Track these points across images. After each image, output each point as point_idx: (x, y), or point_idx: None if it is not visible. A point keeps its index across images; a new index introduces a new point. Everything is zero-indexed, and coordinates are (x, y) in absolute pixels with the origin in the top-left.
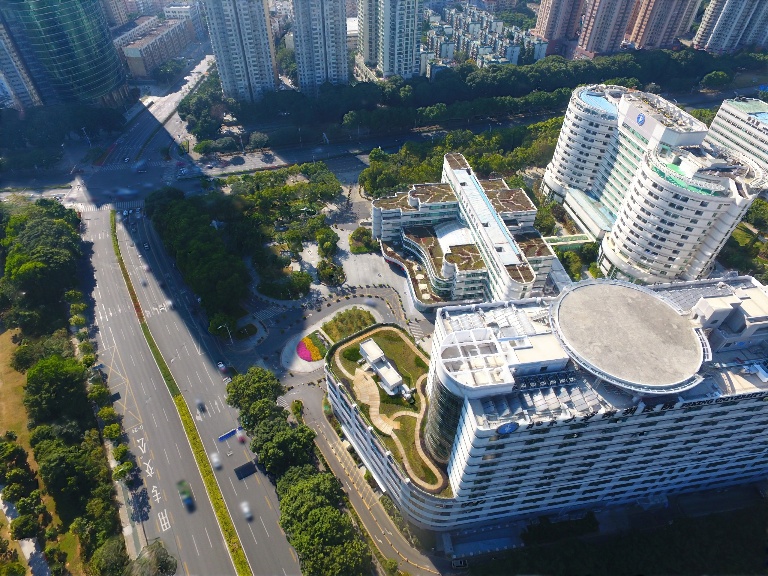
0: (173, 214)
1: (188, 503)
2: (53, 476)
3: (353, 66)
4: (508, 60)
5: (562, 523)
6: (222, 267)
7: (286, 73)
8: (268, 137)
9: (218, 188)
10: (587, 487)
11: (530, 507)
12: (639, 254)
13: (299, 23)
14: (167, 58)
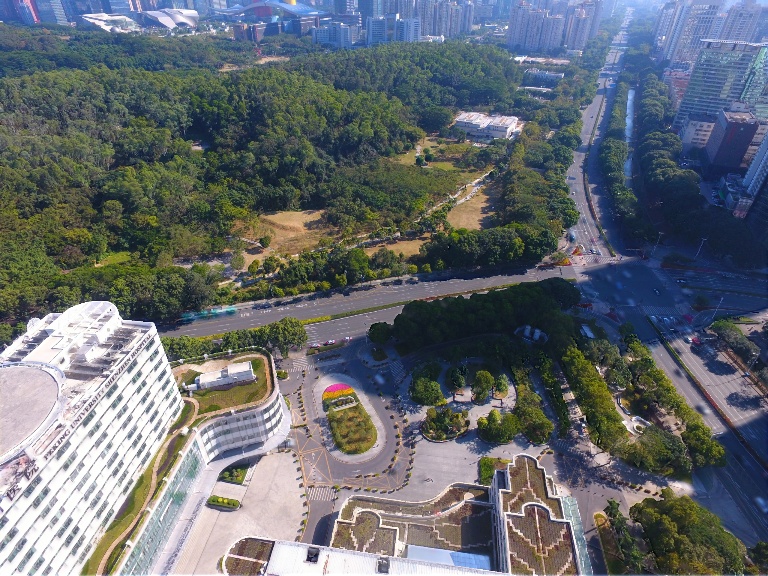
0: None
1: None
2: (288, 268)
3: None
4: None
5: None
6: (419, 312)
7: None
8: None
9: None
10: None
11: None
12: None
13: None
14: None
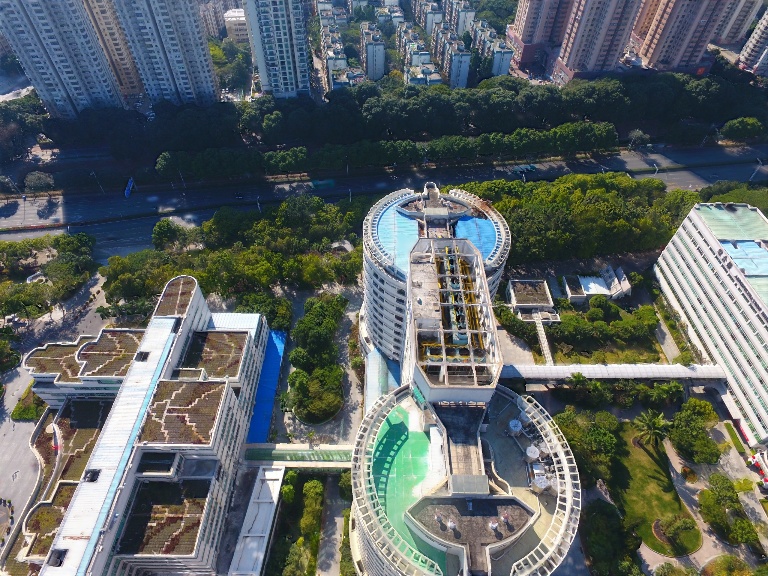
0: None
1: None
2: None
3: None
4: (440, 78)
5: None
6: None
7: None
8: (53, 179)
9: None
10: None
11: None
12: (365, 565)
13: (125, 17)
14: None
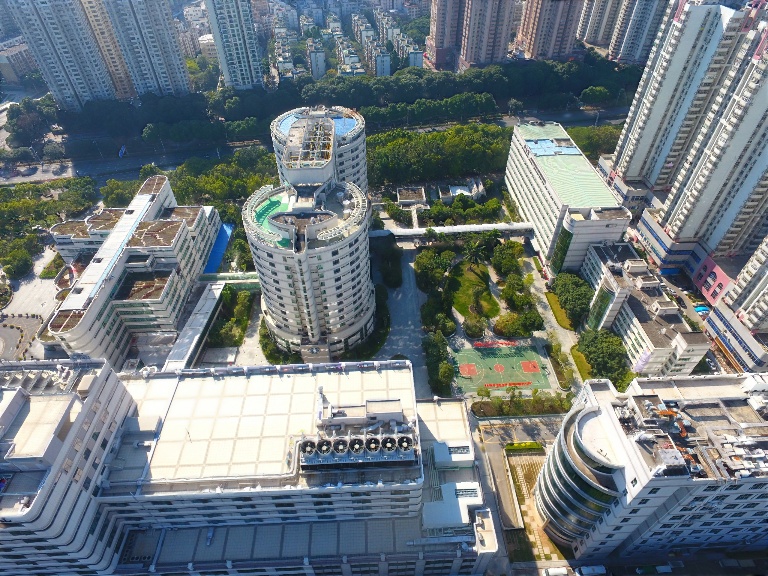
0: None
1: None
2: None
3: None
4: (364, 71)
5: None
6: None
7: None
8: None
9: None
10: None
11: None
12: None
13: (119, 32)
14: None
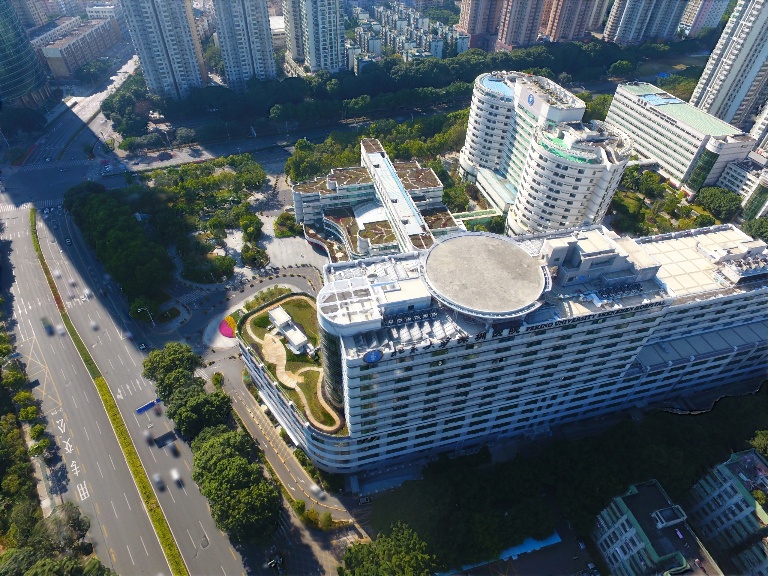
0: (92, 207)
1: (107, 473)
2: None
3: (284, 63)
4: (431, 54)
5: (459, 458)
6: (140, 253)
7: (216, 71)
8: (195, 132)
9: (143, 183)
10: (472, 419)
11: (425, 443)
12: (535, 222)
13: (221, 20)
14: (91, 58)
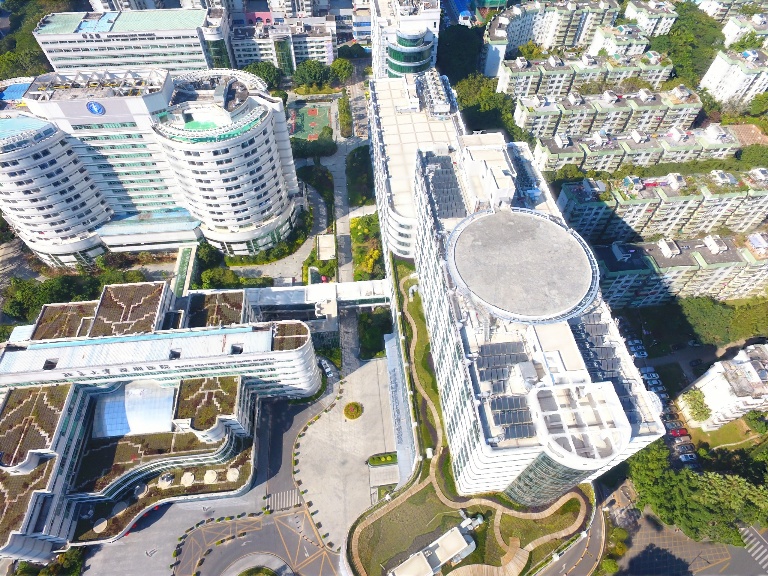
0: None
1: None
2: None
3: None
4: None
5: None
6: None
7: None
8: None
9: None
10: None
11: None
12: (258, 213)
13: None
14: None
